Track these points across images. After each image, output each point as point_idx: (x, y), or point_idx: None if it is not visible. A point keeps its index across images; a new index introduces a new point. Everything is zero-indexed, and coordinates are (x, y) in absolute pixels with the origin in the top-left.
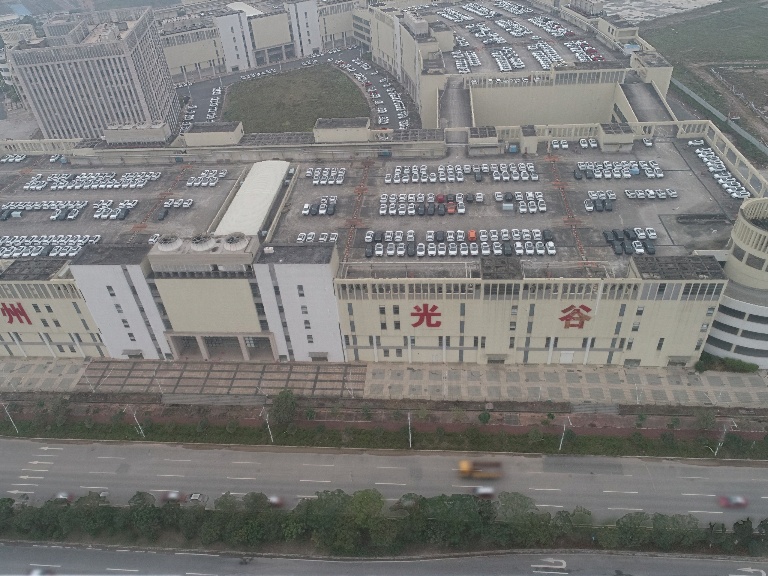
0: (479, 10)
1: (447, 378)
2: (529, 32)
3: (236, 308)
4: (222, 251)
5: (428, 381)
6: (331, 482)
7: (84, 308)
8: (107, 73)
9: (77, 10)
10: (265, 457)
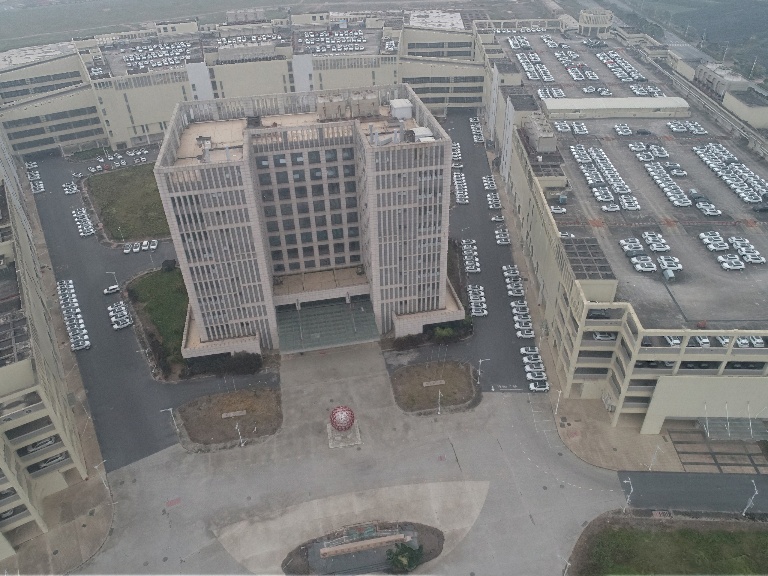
0: None
1: None
2: None
3: None
4: None
5: None
6: None
7: None
8: None
9: None
10: None
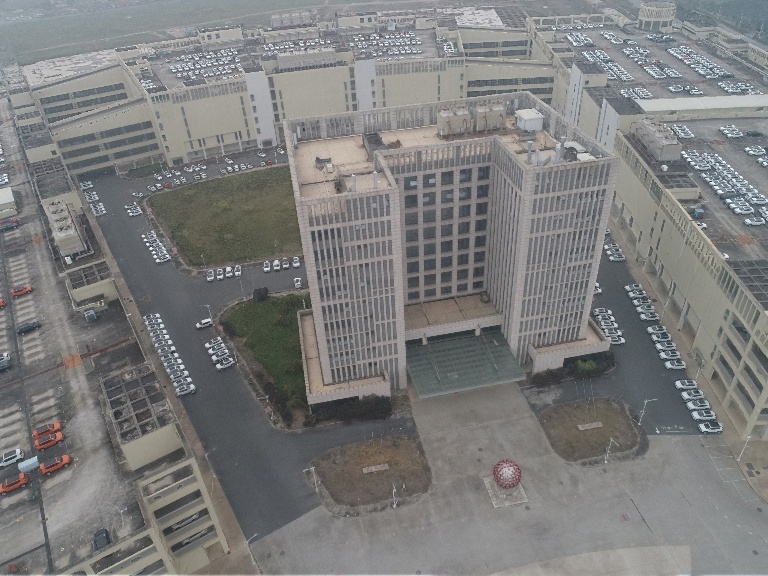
0: None
1: None
2: None
3: None
4: None
5: None
6: None
7: None
8: None
9: None
10: None
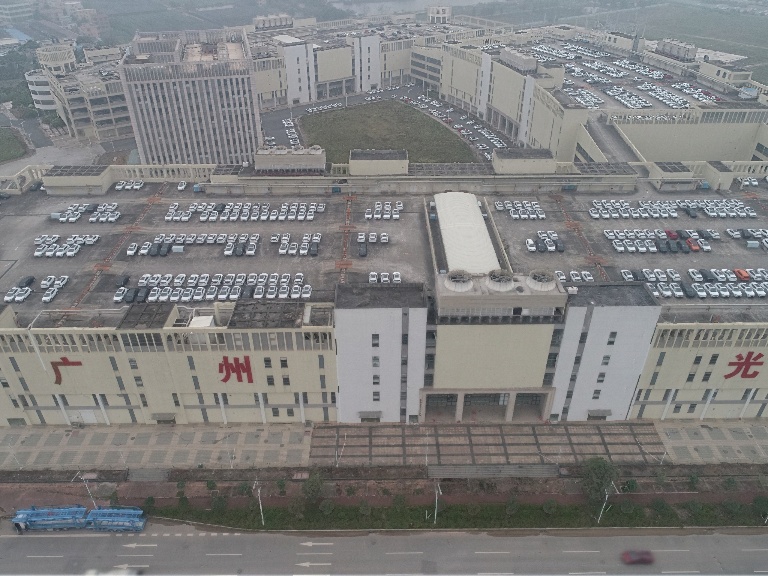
0: (556, 52)
1: (754, 437)
2: (626, 74)
3: (523, 359)
4: (531, 291)
5: (735, 441)
6: (701, 572)
7: (331, 362)
8: (226, 94)
9: (85, 37)
10: (598, 543)
